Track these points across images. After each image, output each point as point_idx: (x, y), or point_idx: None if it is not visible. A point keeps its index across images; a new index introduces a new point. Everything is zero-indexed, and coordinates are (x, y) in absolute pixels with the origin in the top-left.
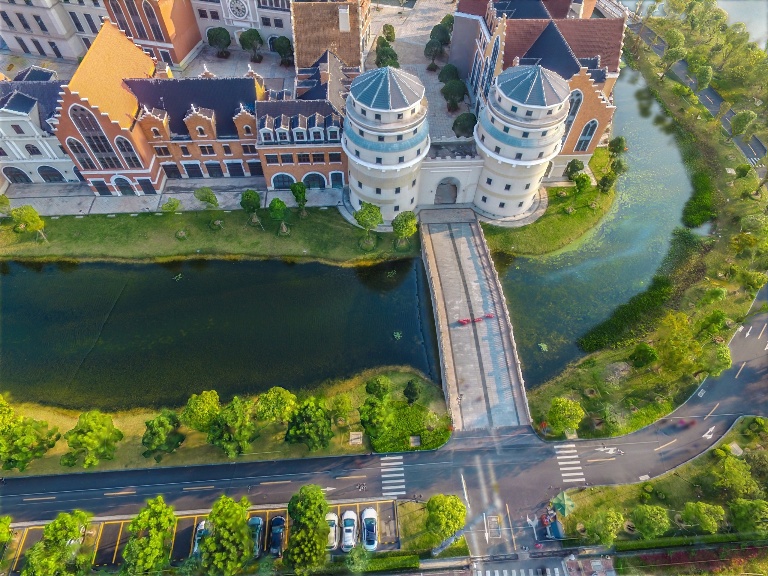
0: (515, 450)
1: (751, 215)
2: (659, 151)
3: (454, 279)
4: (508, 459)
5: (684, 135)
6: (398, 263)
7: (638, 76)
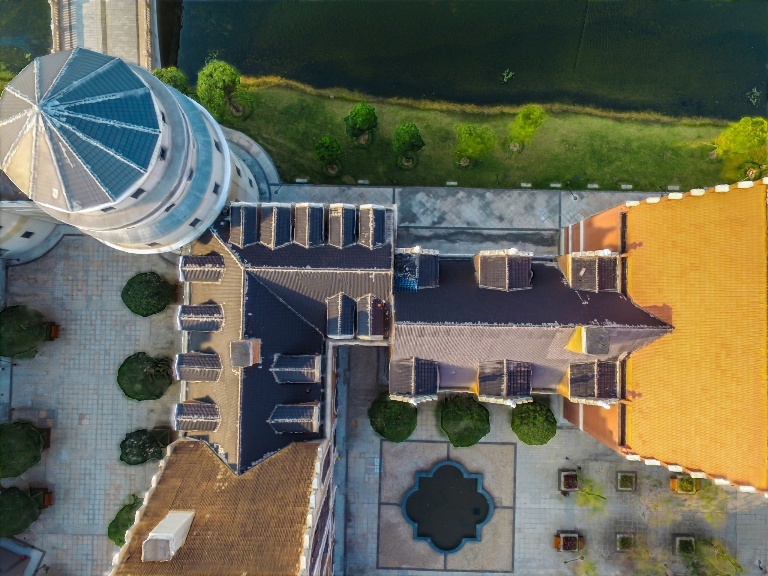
0: None
1: None
2: None
3: (117, 8)
4: None
5: None
6: None
7: None
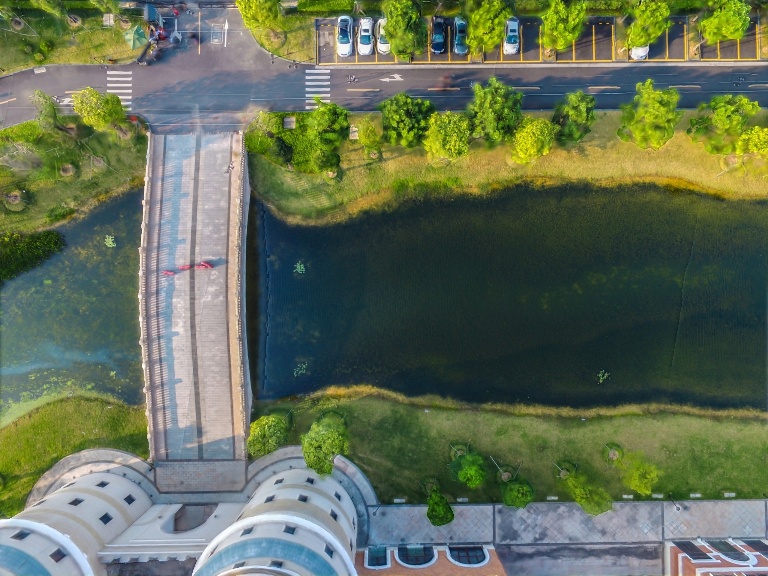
0: (177, 108)
1: None
2: None
3: (208, 340)
4: (188, 99)
5: None
6: (289, 390)
7: None
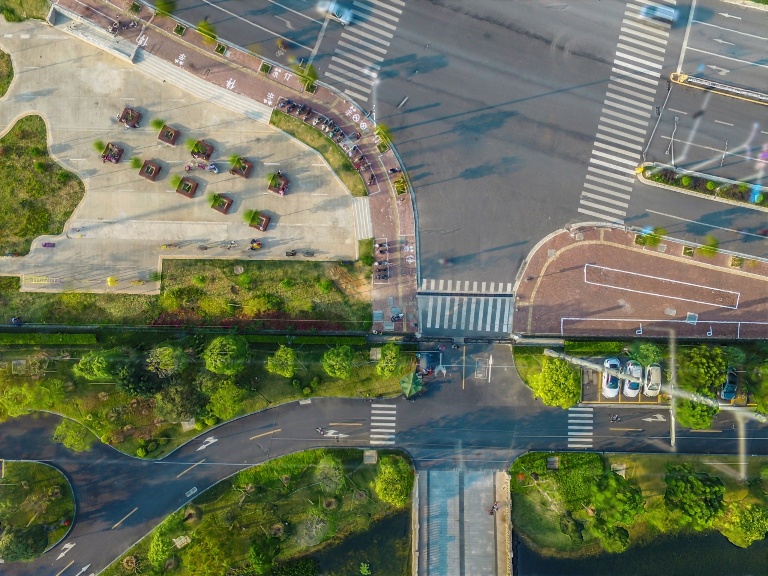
0: (440, 443)
1: None
2: None
3: None
4: (451, 434)
5: None
6: None
7: None
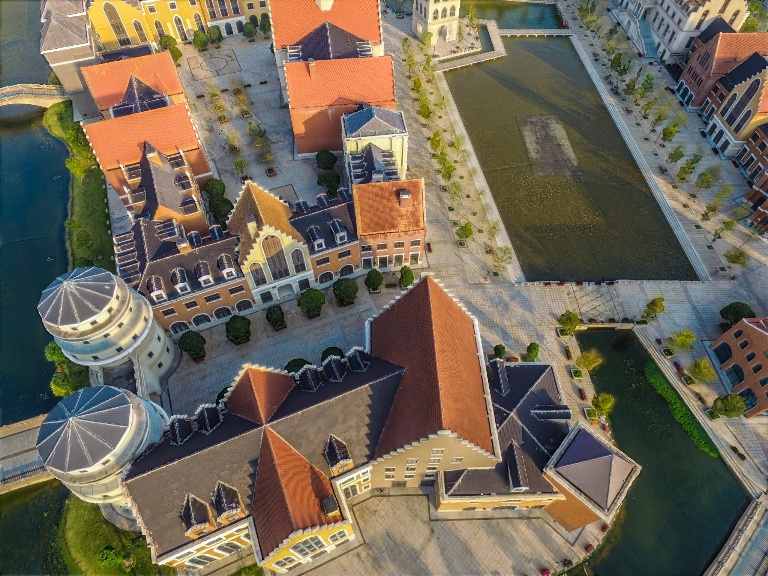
0: None
1: None
2: None
3: (8, 448)
4: None
5: None
6: (58, 398)
7: None
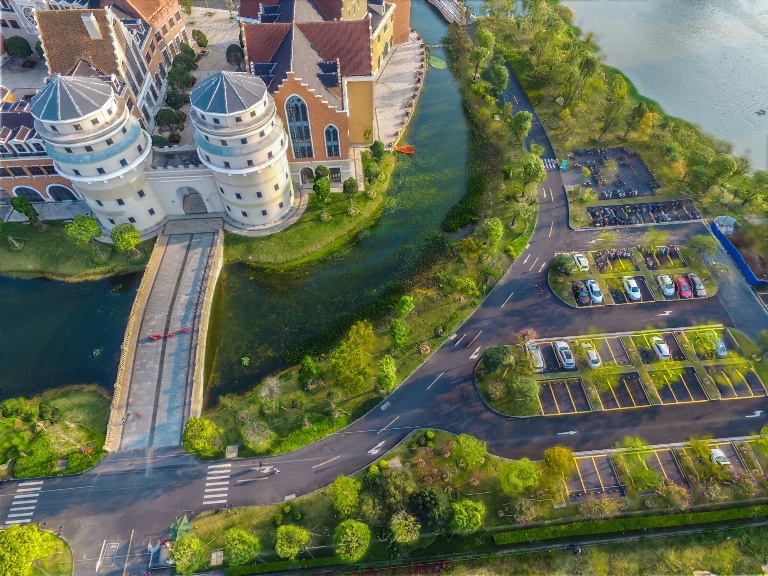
0: (165, 472)
1: (487, 219)
2: (446, 154)
3: (165, 292)
4: (154, 481)
5: (477, 137)
6: (128, 276)
7: (455, 77)
